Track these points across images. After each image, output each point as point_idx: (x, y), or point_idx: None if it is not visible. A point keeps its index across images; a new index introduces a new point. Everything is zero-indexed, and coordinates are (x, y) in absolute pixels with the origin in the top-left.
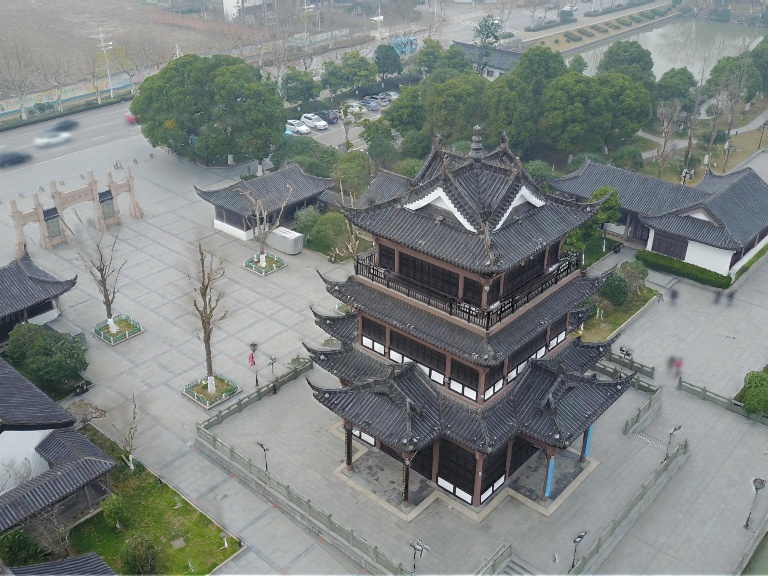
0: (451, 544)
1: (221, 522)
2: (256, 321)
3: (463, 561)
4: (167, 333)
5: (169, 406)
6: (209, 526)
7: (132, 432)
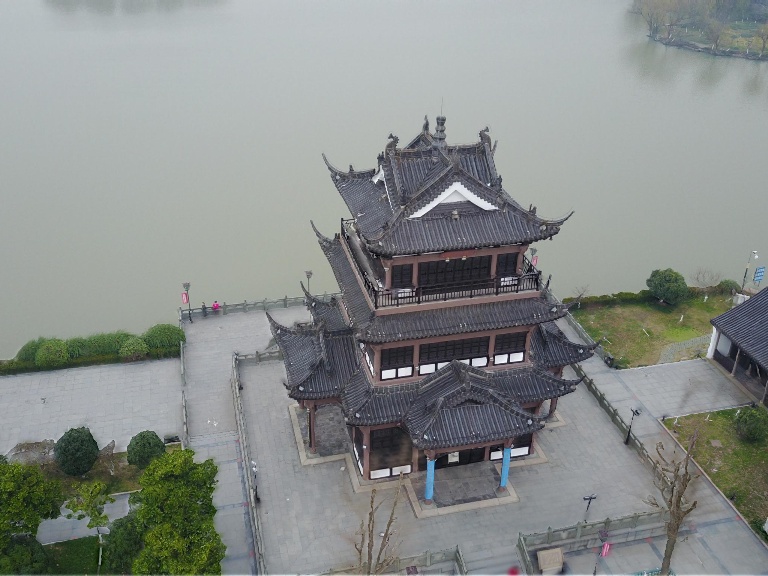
0: None
1: None
2: None
3: None
4: None
5: None
6: None
7: None
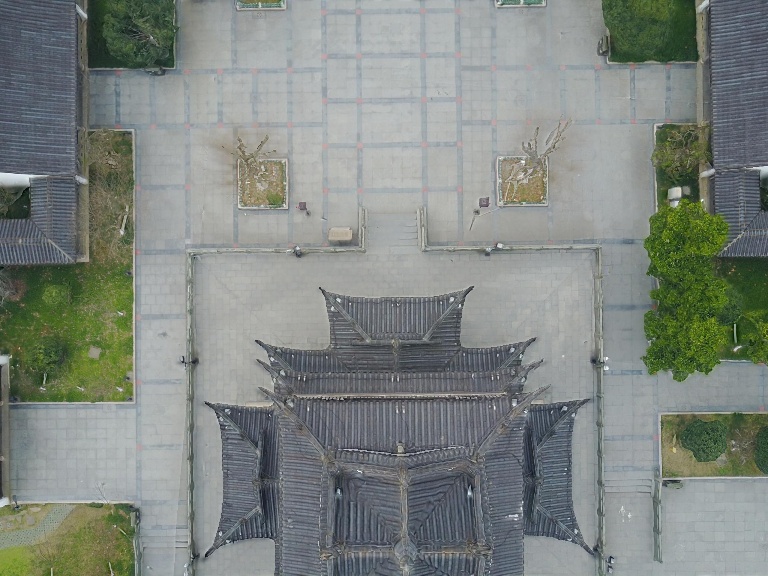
0: (254, 553)
1: (140, 359)
2: (405, 97)
3: (245, 573)
4: (304, 34)
5: (213, 169)
6: (128, 356)
7: (117, 225)
